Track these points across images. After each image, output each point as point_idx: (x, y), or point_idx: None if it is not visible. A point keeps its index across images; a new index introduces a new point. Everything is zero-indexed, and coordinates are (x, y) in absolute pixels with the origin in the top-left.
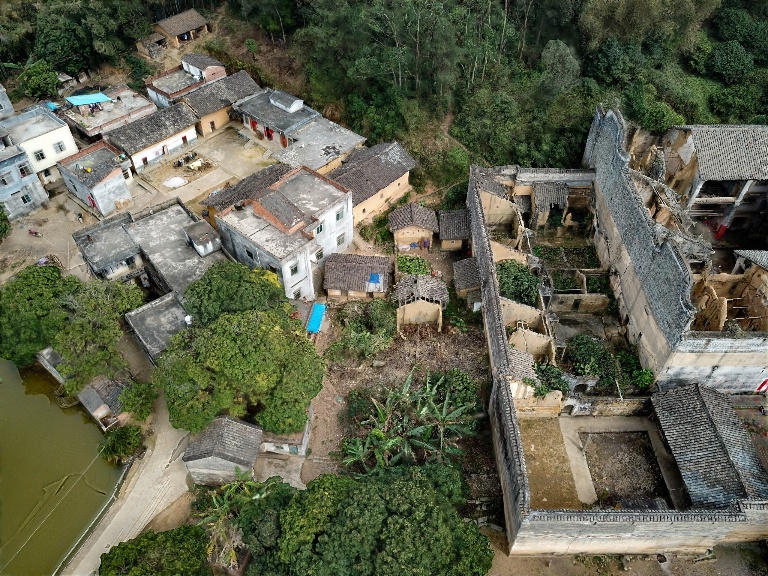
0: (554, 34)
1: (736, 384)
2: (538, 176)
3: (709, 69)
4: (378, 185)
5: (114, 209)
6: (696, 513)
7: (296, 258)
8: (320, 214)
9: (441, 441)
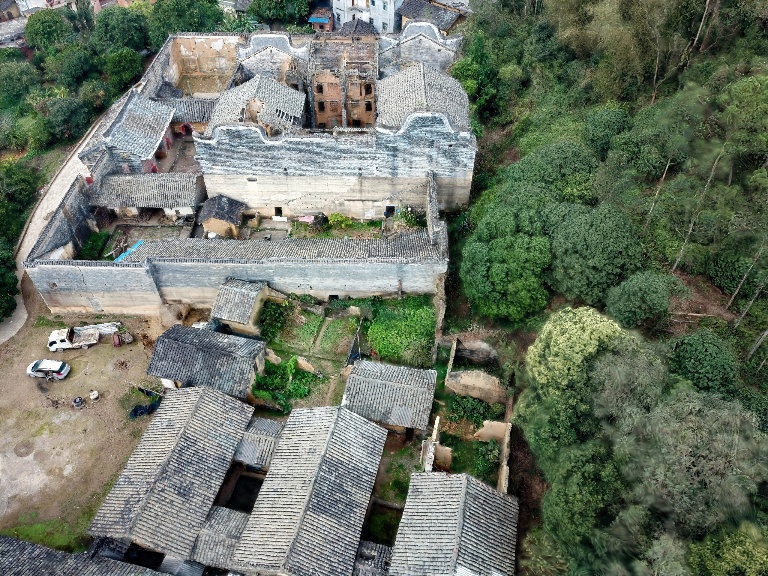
0: None
1: None
2: None
3: None
4: None
5: None
6: (150, 68)
7: None
8: None
9: (219, 28)
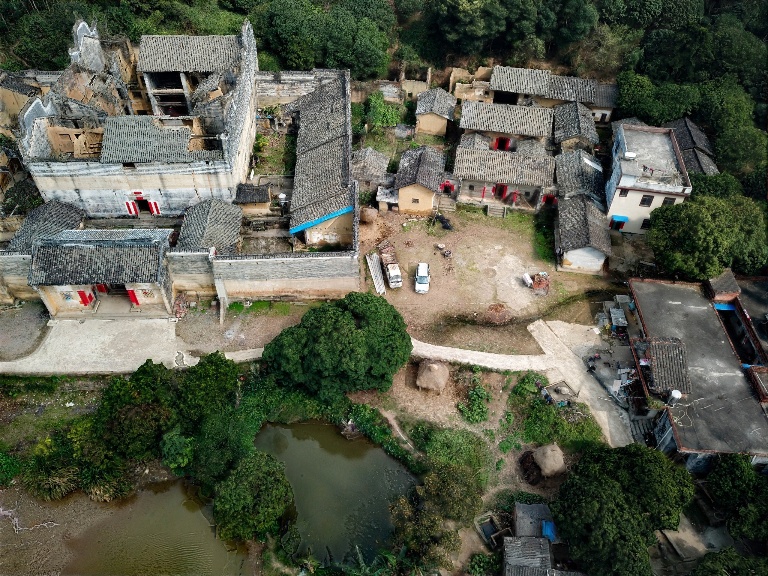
0: None
1: (109, 208)
2: (52, 78)
3: (234, 5)
4: None
5: None
6: None
7: None
8: None
9: None
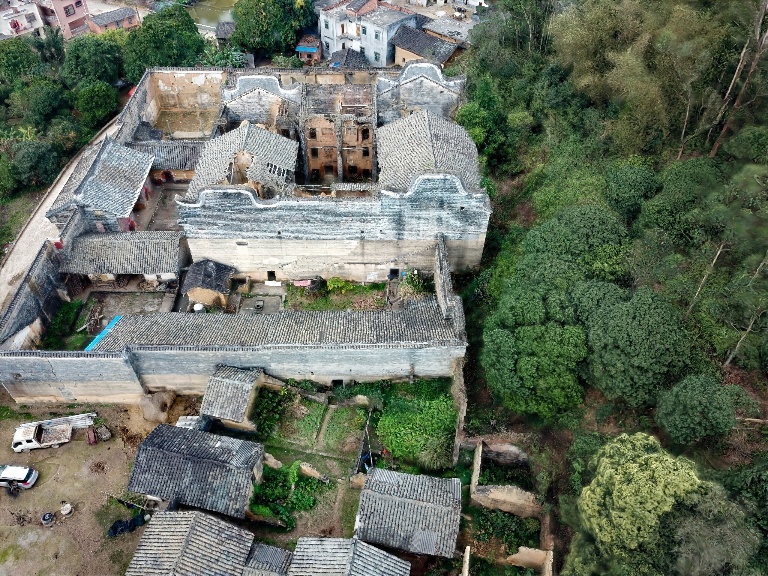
0: None
1: None
2: None
3: None
4: (413, 48)
5: (415, 4)
6: (125, 109)
7: (328, 18)
8: (365, 20)
9: (200, 61)
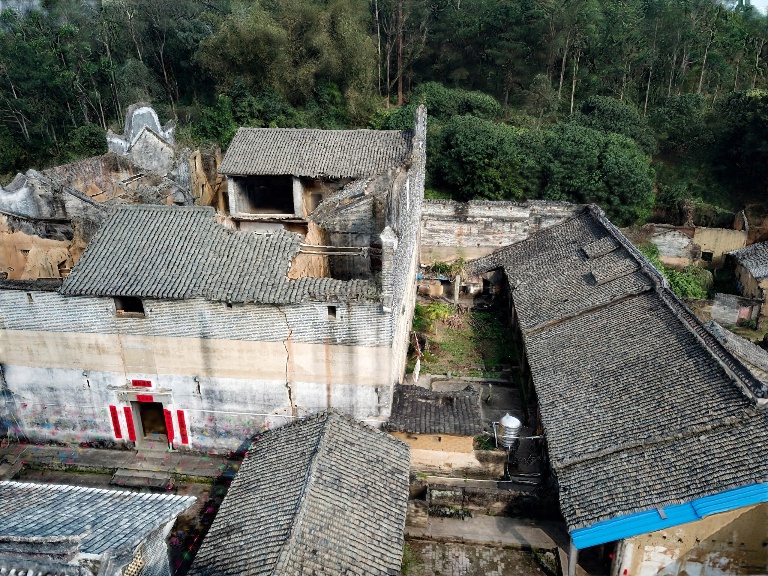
0: (206, 93)
1: (69, 417)
2: None
3: None
4: None
5: None
6: None
7: None
8: None
9: None
